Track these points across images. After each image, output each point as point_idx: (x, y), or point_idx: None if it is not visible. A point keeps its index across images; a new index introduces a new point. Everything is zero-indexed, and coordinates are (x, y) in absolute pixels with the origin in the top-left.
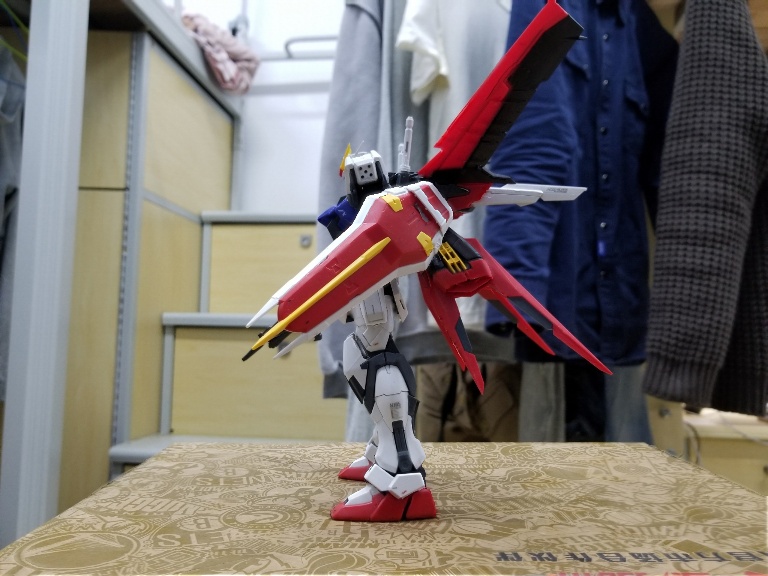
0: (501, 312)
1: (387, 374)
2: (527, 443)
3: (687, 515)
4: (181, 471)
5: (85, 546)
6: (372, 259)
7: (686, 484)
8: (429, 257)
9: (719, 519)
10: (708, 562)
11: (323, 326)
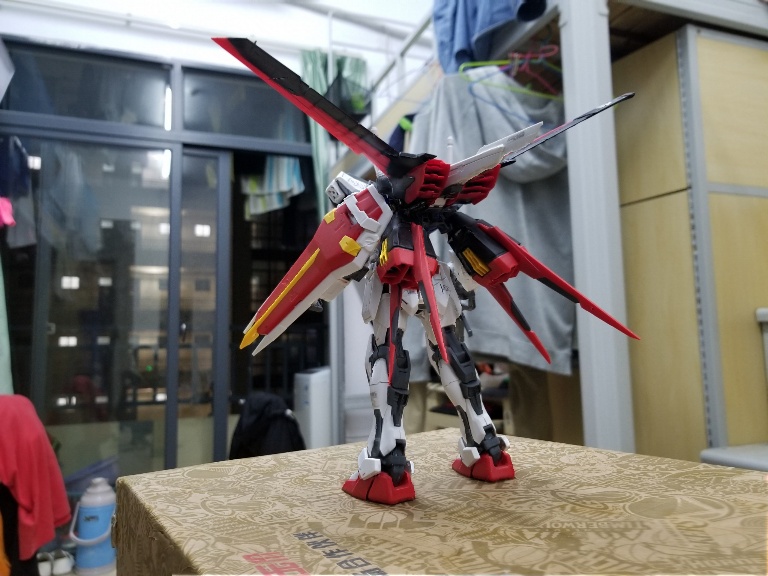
0: None
1: (375, 366)
2: (745, 470)
3: (583, 575)
4: None
5: None
6: (308, 269)
7: (760, 556)
8: (360, 256)
9: None
10: None
11: (280, 328)
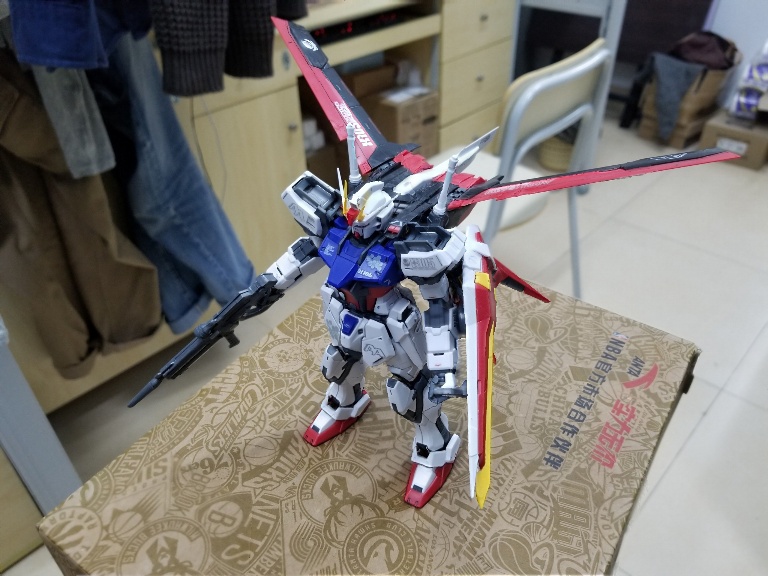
0: None
1: None
2: None
3: (536, 334)
4: (183, 562)
5: None
6: None
7: None
8: None
9: (552, 329)
10: (604, 386)
11: None
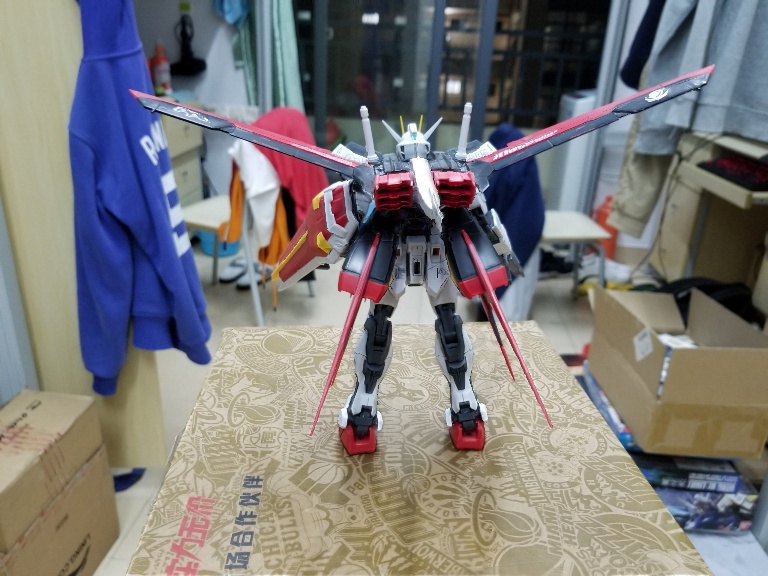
0: None
1: None
2: (679, 545)
3: None
4: None
5: (292, 342)
6: None
7: None
8: (332, 254)
9: None
10: None
11: (291, 281)
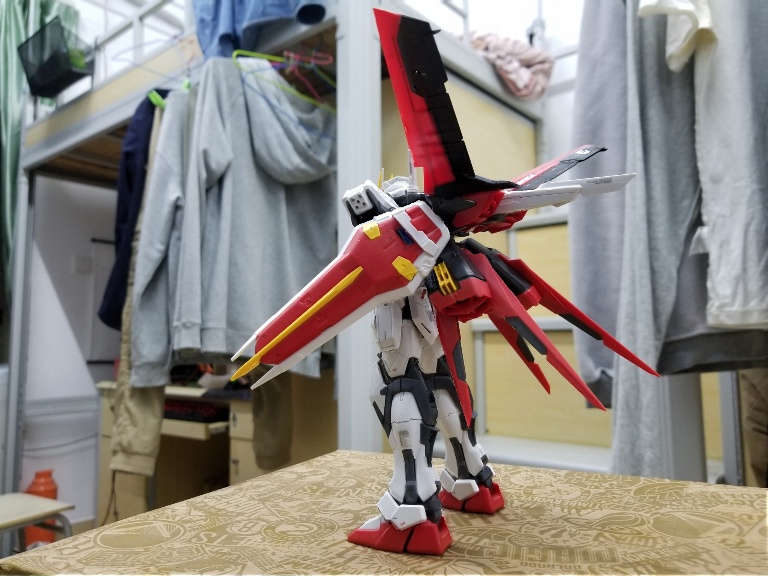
0: (579, 327)
1: (399, 401)
2: (685, 482)
3: None
4: (304, 477)
5: (147, 532)
6: (344, 290)
7: None
8: (414, 281)
9: None
10: None
11: (296, 357)
